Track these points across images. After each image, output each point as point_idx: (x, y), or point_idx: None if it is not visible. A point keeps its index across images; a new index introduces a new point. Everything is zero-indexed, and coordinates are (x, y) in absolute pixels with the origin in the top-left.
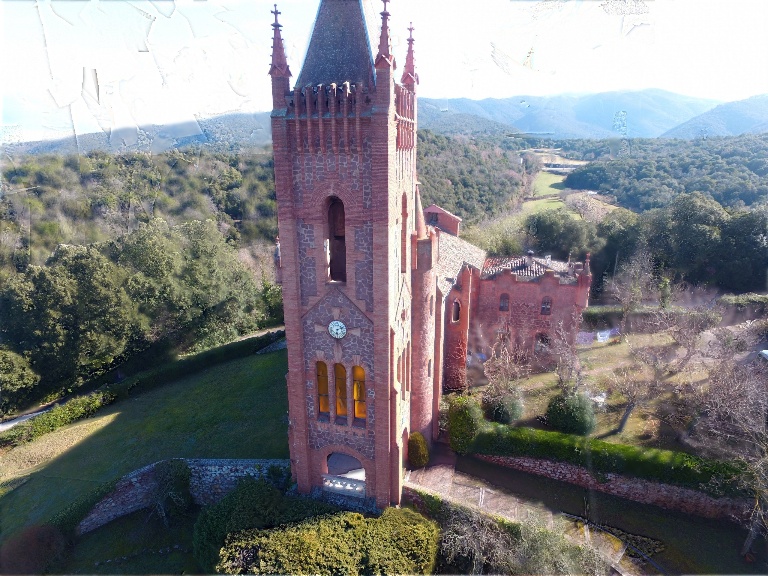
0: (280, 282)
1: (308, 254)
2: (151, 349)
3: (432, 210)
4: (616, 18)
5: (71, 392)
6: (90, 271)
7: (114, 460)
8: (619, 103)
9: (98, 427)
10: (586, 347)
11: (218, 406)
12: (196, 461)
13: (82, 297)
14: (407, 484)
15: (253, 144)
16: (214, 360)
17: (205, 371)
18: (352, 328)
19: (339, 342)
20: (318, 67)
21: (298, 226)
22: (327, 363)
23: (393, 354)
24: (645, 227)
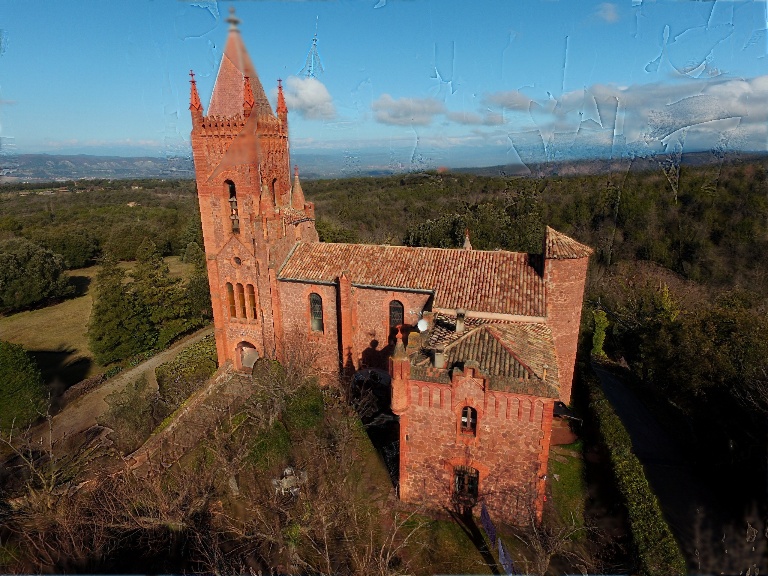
0: None
1: None
2: None
3: None
4: (223, 1)
5: None
6: None
7: None
8: None
9: None
10: (489, 544)
11: None
12: None
13: None
14: (225, 364)
15: (744, 137)
16: None
17: None
18: None
19: None
20: None
21: None
22: None
23: (210, 271)
24: None
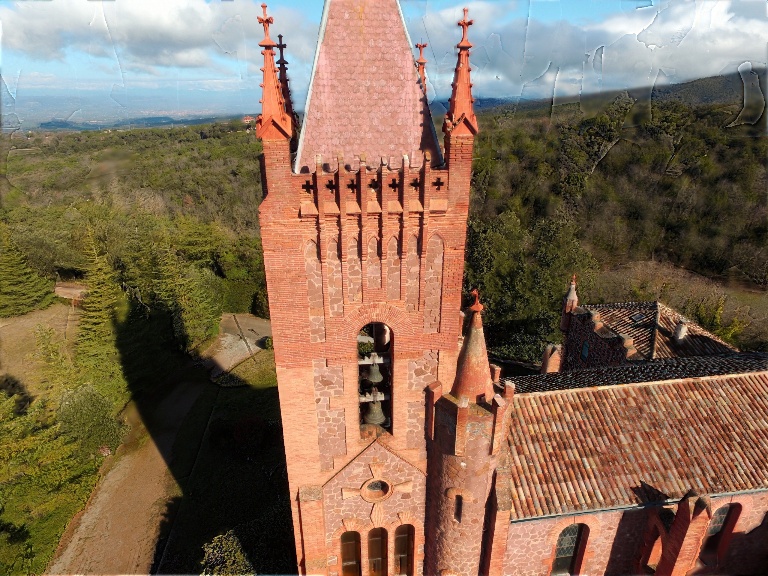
0: (562, 330)
1: None
2: None
3: None
4: None
5: None
6: None
7: None
8: None
9: None
10: None
11: None
12: None
13: None
14: None
15: None
16: None
17: None
18: None
19: None
20: None
21: None
22: None
23: (302, 522)
24: None
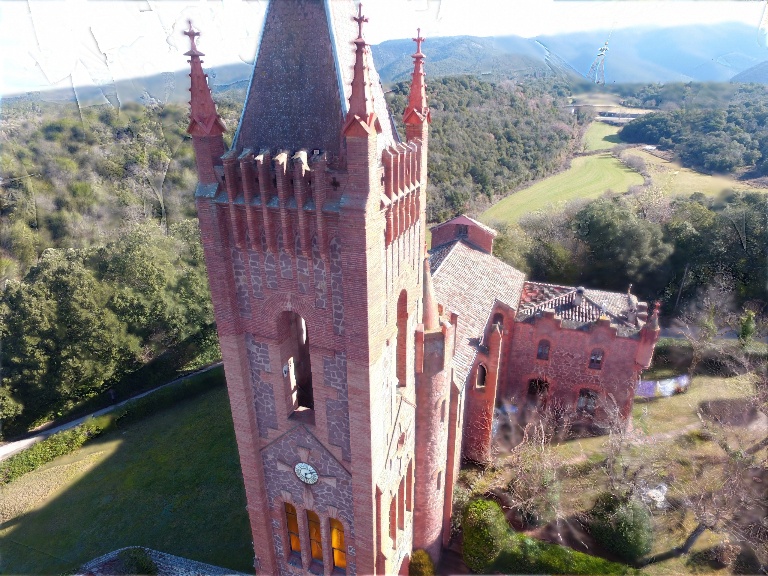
0: None
1: (263, 378)
2: (145, 368)
3: (461, 222)
4: (752, 6)
5: (61, 415)
6: (71, 288)
7: (83, 528)
8: (702, 65)
9: (78, 472)
10: (641, 397)
11: (204, 458)
12: (161, 557)
13: (63, 319)
14: None
15: None
16: (212, 383)
17: (201, 397)
18: (325, 476)
19: (309, 488)
20: (265, 117)
21: (247, 342)
22: (295, 506)
23: (380, 516)
24: (724, 230)
